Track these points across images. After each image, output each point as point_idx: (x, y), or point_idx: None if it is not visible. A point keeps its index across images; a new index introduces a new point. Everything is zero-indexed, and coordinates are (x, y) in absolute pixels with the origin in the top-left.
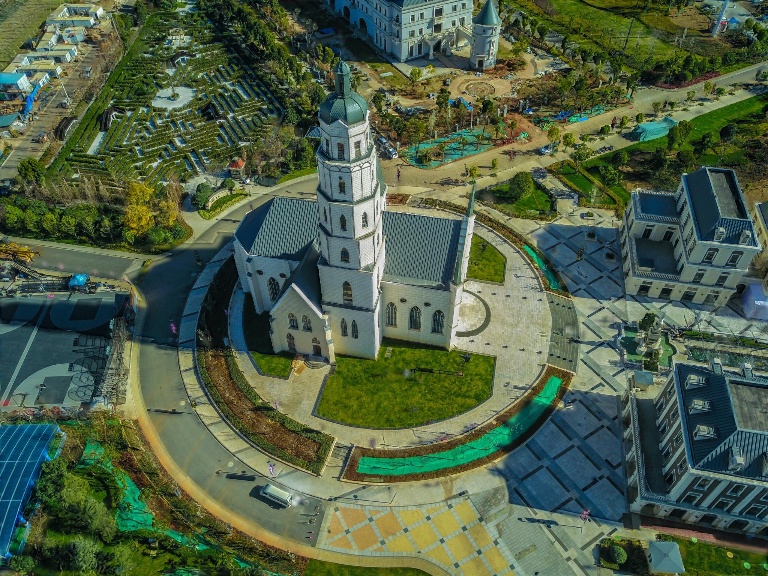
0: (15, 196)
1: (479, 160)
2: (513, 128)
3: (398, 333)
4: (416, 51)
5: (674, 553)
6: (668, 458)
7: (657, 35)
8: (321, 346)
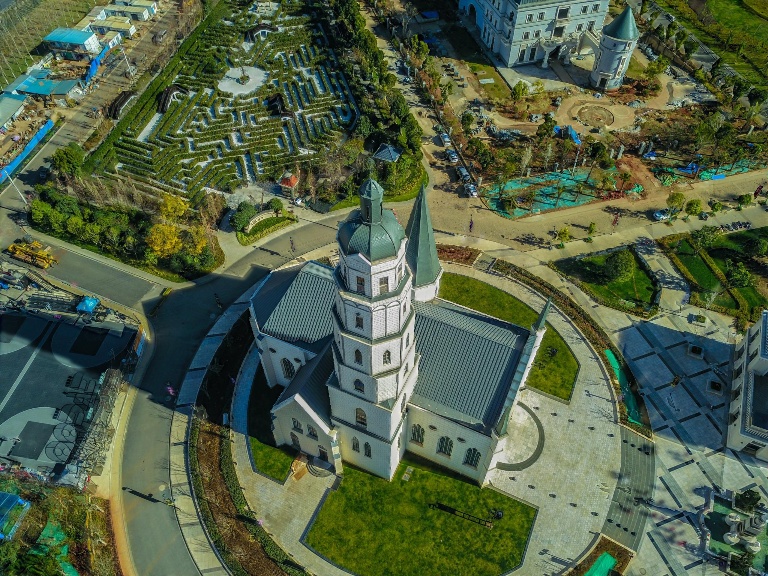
0: (51, 183)
1: (575, 215)
2: (625, 181)
3: (424, 452)
4: (528, 56)
5: None
6: None
7: None
8: (328, 454)
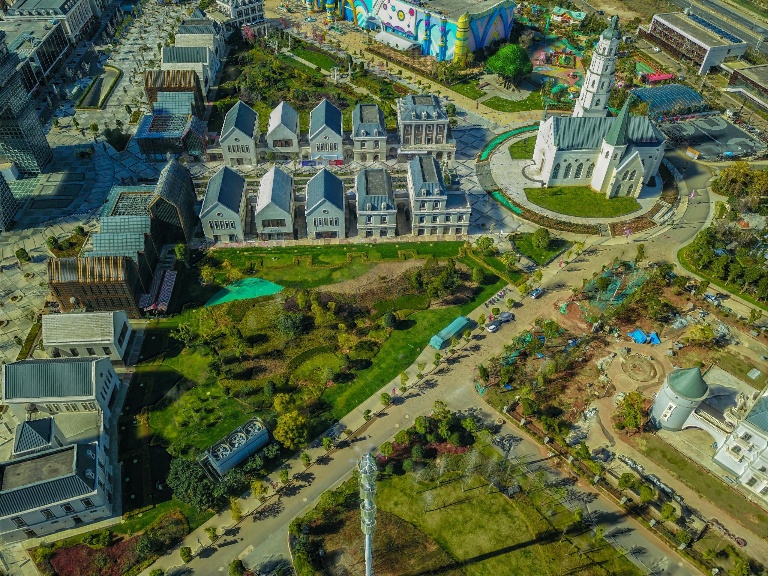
0: None
1: (585, 276)
2: None
3: None
4: None
5: None
6: None
7: (460, 570)
8: None
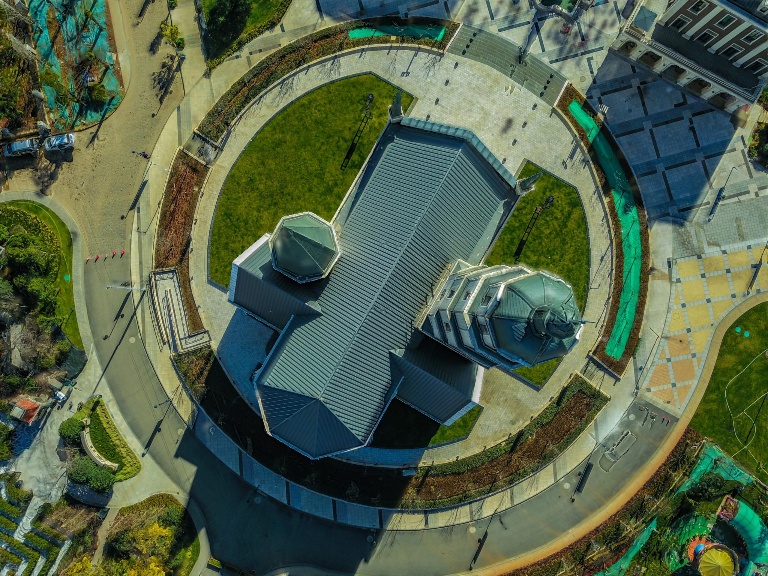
0: None
1: (124, 7)
2: None
3: None
4: None
5: None
6: (738, 54)
7: None
8: None
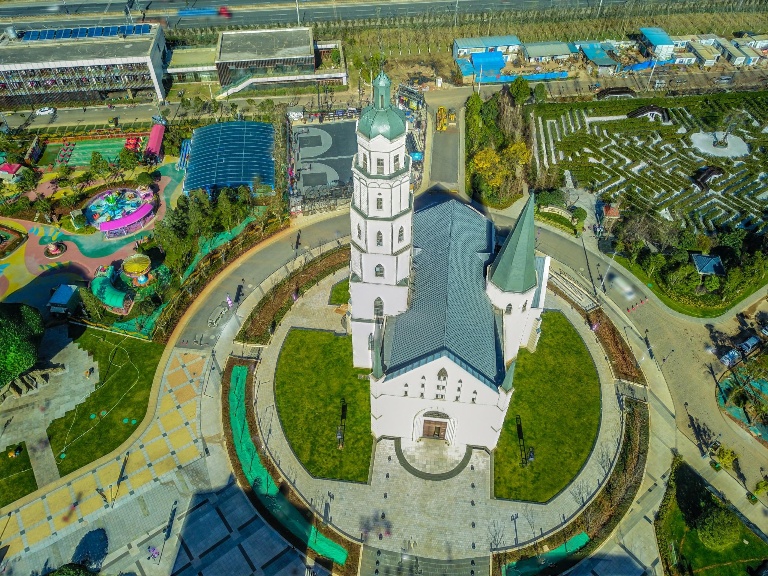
0: None
1: None
2: None
3: None
4: None
5: None
6: None
7: None
8: None
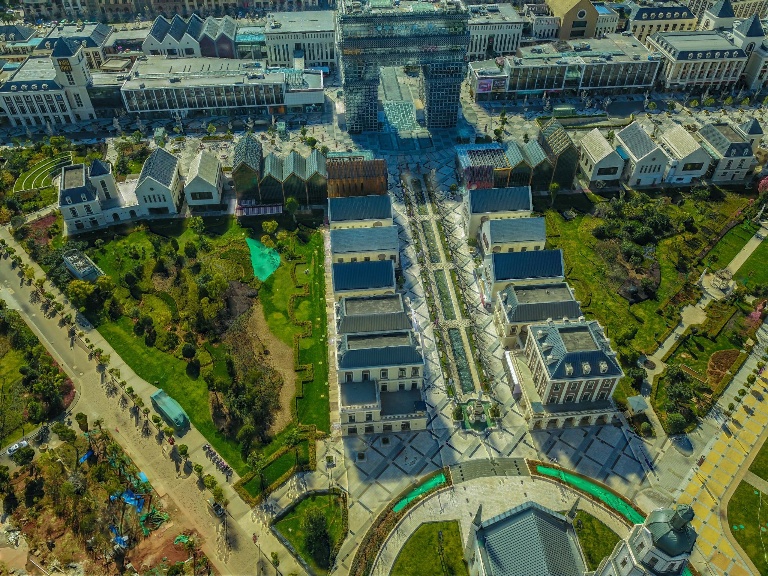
0: None
1: None
2: None
3: None
4: None
5: (634, 399)
6: None
7: None
8: None
